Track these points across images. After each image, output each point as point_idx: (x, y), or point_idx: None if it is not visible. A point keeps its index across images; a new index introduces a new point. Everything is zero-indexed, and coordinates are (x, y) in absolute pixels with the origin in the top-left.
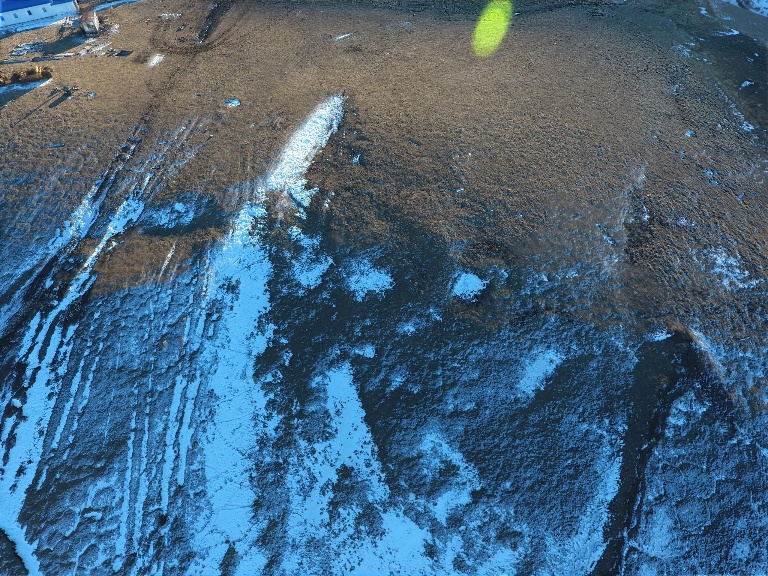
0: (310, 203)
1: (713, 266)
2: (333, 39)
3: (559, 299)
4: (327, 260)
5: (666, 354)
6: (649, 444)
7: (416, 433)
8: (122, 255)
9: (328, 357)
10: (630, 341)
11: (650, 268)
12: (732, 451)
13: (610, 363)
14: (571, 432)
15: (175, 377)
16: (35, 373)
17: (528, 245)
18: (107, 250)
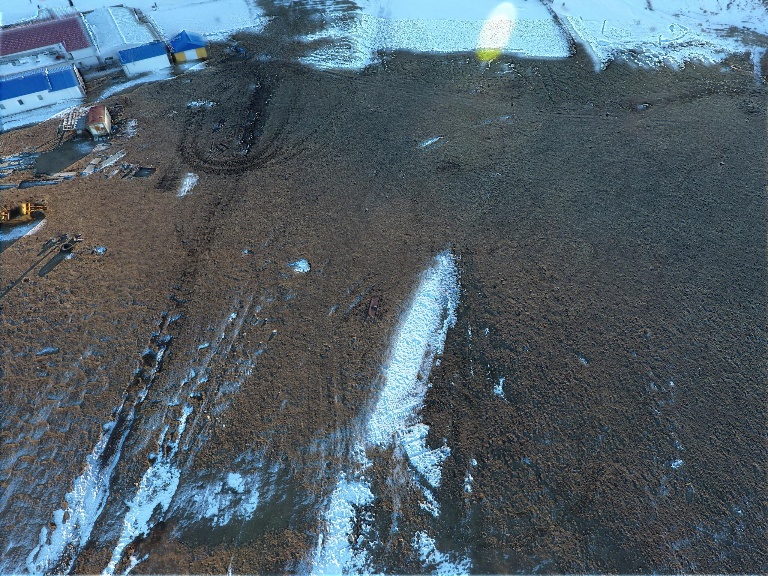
0: (440, 480)
1: None
2: (419, 147)
3: None
4: None
5: None
6: None
7: None
8: None
9: None
10: None
11: None
12: None
13: None
14: None
15: None
16: None
17: None
18: None
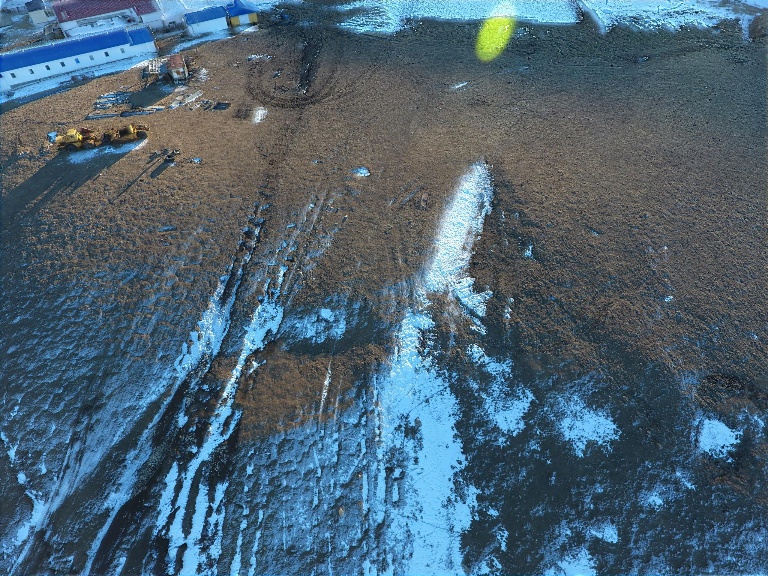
0: (486, 312)
1: None
2: (451, 89)
3: None
4: (526, 394)
5: None
6: None
7: None
8: (268, 381)
9: (556, 539)
10: None
11: None
12: None
13: None
14: None
15: (361, 563)
16: (181, 554)
17: None
18: (248, 374)
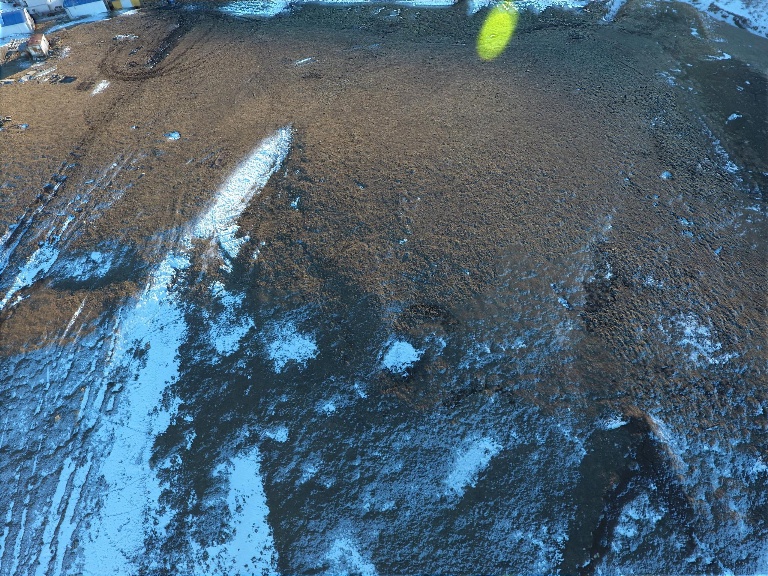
0: (238, 254)
1: (680, 337)
2: (292, 64)
3: (501, 375)
4: (248, 322)
5: (619, 446)
6: (592, 561)
7: (324, 538)
8: (25, 312)
9: (235, 440)
10: (579, 429)
11: (608, 338)
12: (689, 572)
13: (554, 456)
14: (502, 542)
15: (63, 460)
16: None
17: (472, 308)
18: (10, 306)
